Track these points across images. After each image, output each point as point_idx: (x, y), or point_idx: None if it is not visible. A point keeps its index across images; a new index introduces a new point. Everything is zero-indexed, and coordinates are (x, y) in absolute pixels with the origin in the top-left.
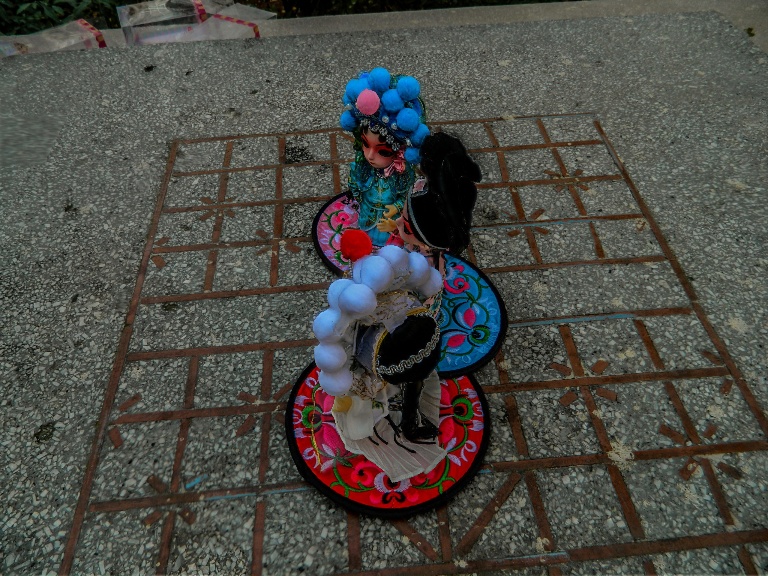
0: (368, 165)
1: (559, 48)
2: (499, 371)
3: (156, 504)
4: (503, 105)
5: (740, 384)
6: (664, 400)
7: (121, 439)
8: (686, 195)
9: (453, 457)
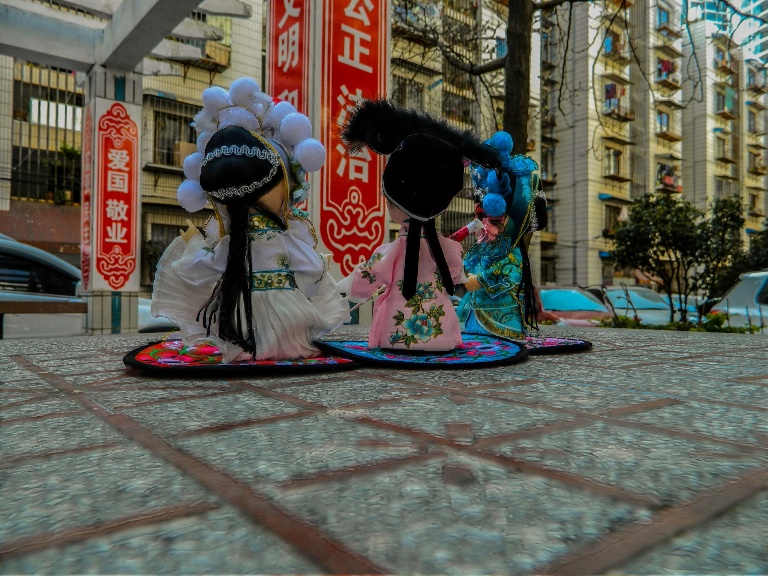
0: (480, 245)
1: None
2: None
3: None
4: None
5: None
6: None
7: None
8: None
9: None
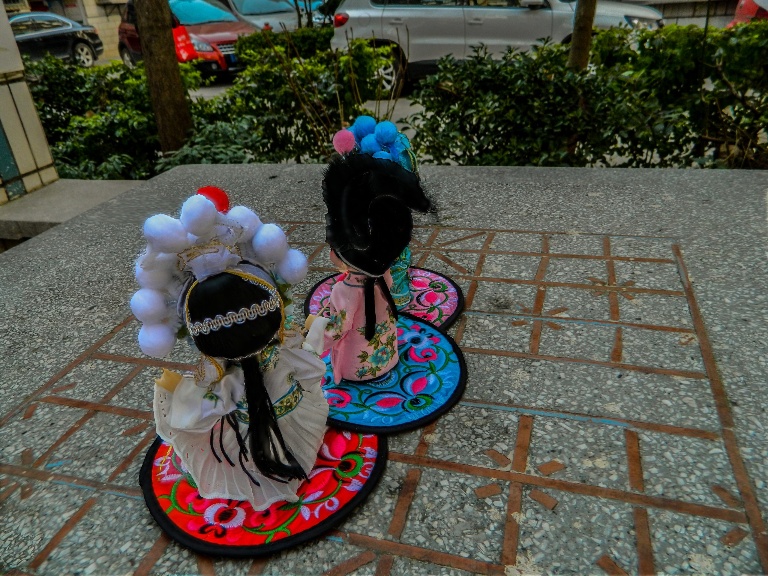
0: None
1: (665, 188)
2: (420, 442)
3: (12, 472)
4: (573, 223)
5: (759, 539)
6: (623, 527)
7: (33, 413)
8: (766, 321)
9: (305, 509)
